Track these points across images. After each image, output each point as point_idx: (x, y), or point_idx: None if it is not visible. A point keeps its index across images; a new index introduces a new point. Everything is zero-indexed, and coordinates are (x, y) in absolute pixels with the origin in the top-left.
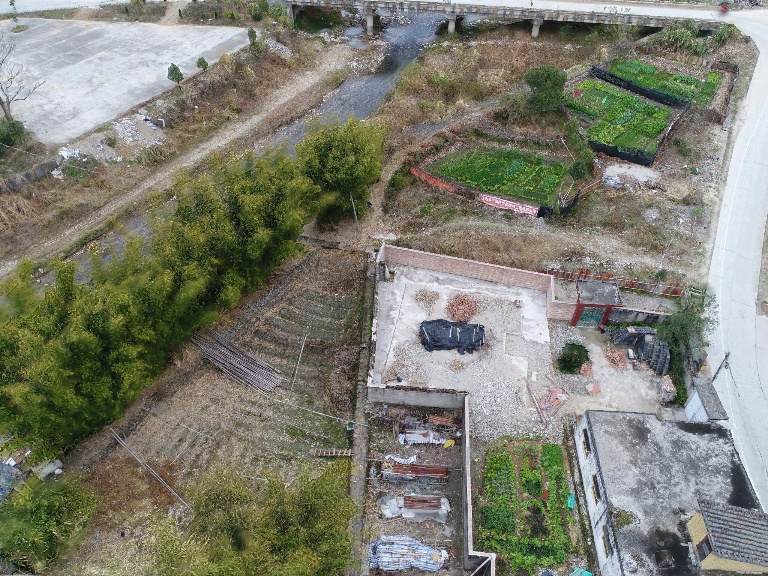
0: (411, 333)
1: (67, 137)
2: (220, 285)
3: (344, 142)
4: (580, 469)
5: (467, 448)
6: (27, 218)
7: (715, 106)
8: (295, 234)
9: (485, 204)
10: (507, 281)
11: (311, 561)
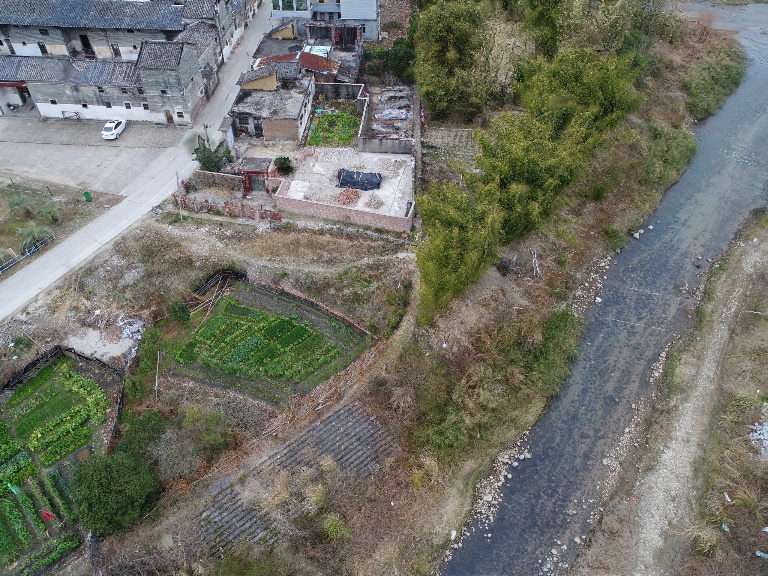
0: None
1: None
2: None
3: None
4: None
5: (362, 122)
6: None
7: None
8: None
9: None
10: None
11: (431, 50)
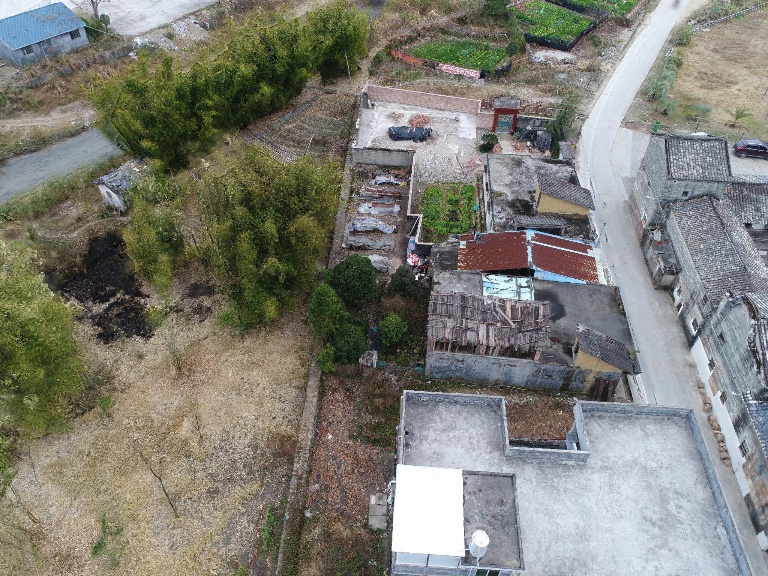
0: (383, 132)
1: (138, 32)
2: (258, 89)
3: (341, 12)
4: (483, 193)
5: (412, 175)
6: (116, 79)
7: (628, 16)
8: None
9: (443, 71)
10: (451, 108)
11: None
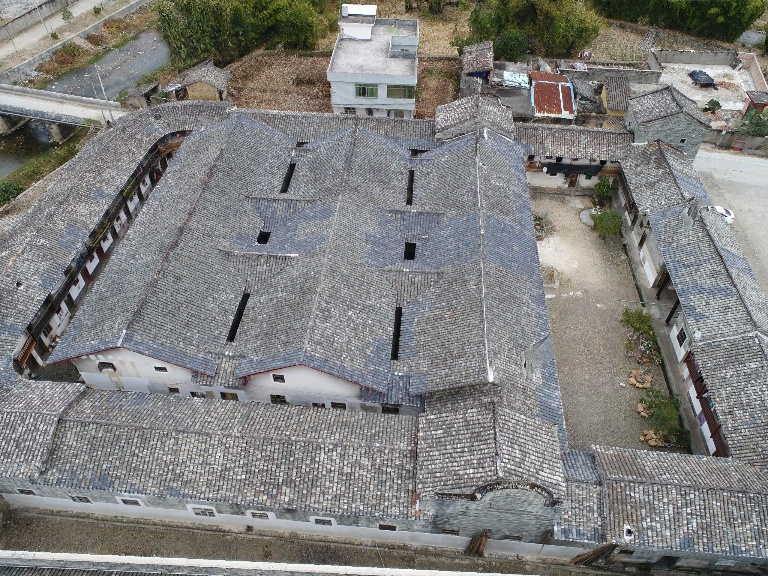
0: None
1: None
2: None
3: None
4: None
5: None
6: None
7: None
8: (734, 23)
9: None
10: None
11: None
